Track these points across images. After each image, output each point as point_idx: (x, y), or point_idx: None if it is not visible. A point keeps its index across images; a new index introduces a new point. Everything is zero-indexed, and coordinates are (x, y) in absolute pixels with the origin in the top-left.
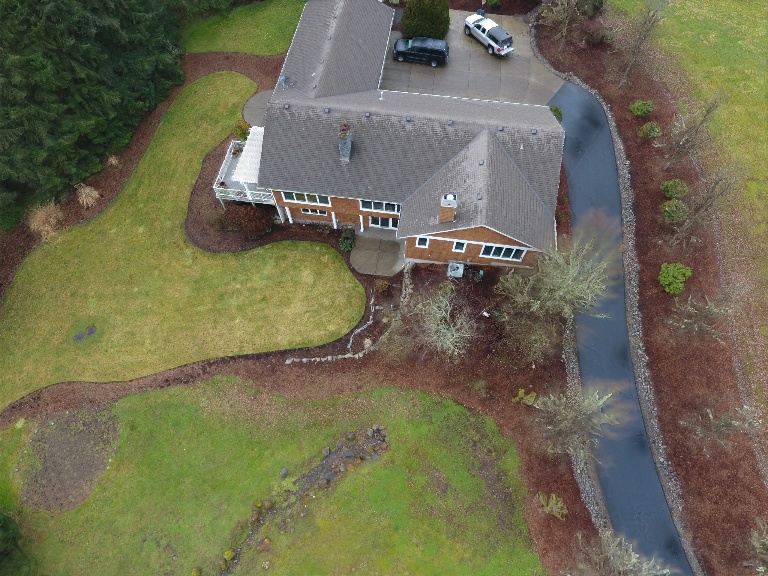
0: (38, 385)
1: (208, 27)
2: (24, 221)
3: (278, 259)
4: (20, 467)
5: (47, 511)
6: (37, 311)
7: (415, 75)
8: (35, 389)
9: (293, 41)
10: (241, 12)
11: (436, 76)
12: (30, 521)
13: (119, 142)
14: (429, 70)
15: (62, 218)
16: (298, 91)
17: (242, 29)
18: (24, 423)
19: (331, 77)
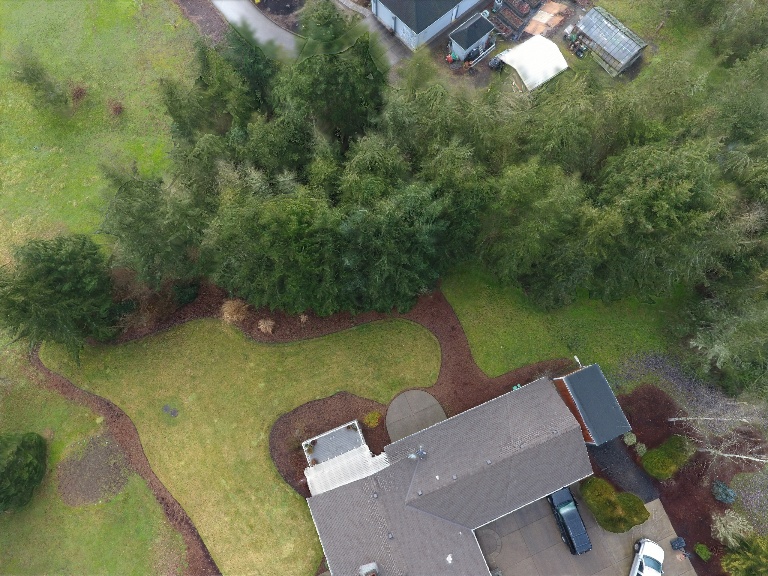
0: (126, 409)
1: (480, 280)
2: (224, 299)
3: (290, 513)
4: (75, 446)
5: (58, 488)
6: (172, 362)
7: (539, 526)
8: (123, 409)
9: (485, 404)
10: (516, 295)
11: (551, 549)
12: (49, 482)
13: (320, 310)
14: (555, 536)
15: (242, 318)
16: (414, 472)
17: (495, 314)
18: (101, 422)
19: (444, 496)
